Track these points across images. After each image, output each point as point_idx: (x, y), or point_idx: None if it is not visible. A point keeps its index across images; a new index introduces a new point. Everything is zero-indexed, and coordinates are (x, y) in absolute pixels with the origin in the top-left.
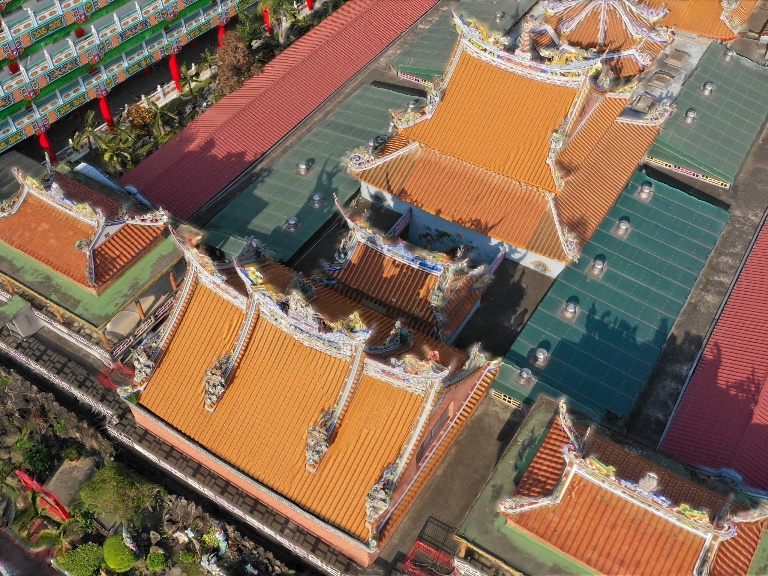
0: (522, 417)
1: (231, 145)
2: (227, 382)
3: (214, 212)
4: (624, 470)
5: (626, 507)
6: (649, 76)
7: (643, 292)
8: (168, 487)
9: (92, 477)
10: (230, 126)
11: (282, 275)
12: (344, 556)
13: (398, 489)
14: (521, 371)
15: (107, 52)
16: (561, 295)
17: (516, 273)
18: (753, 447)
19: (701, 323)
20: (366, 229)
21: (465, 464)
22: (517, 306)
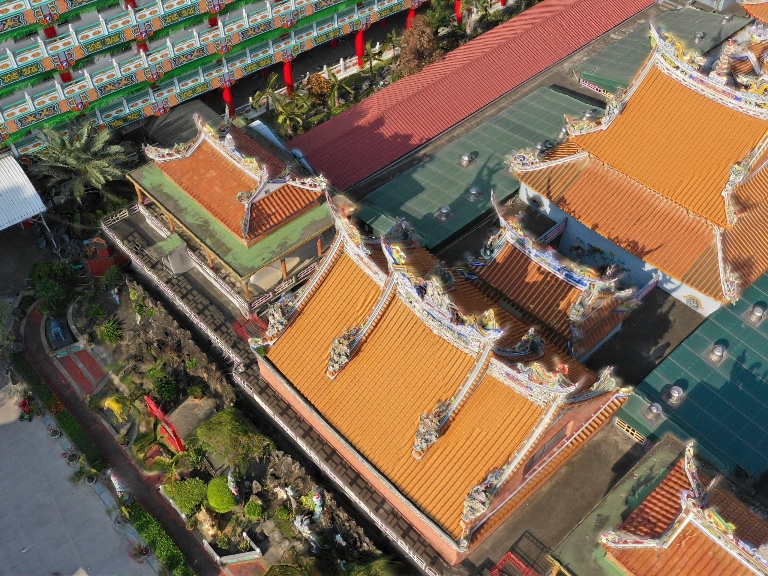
0: (643, 452)
1: (399, 126)
2: (352, 353)
3: (371, 188)
4: (744, 531)
5: (739, 570)
6: None
7: None
8: (278, 442)
9: None
10: (402, 107)
11: (425, 261)
12: (432, 549)
13: (499, 495)
14: (651, 405)
15: (300, 19)
16: (710, 335)
17: (665, 304)
18: None
19: None
20: (517, 230)
21: (573, 487)
22: (660, 338)
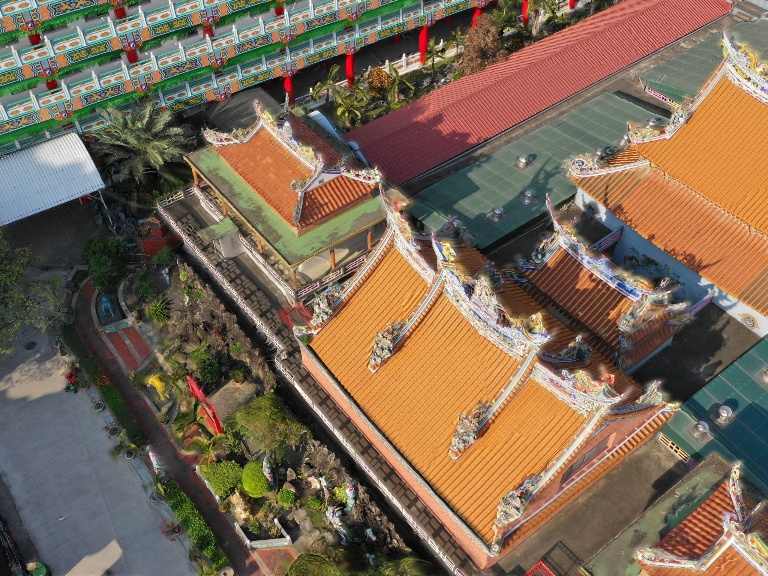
0: (686, 471)
1: (458, 124)
2: (395, 348)
3: (425, 185)
4: None
5: None
6: None
7: None
8: (315, 432)
9: (250, 402)
10: (462, 105)
11: (474, 260)
12: (463, 551)
13: (535, 502)
14: (698, 423)
15: (365, 12)
16: (764, 356)
17: (719, 321)
18: None
19: None
20: (571, 235)
21: (611, 500)
22: (711, 355)
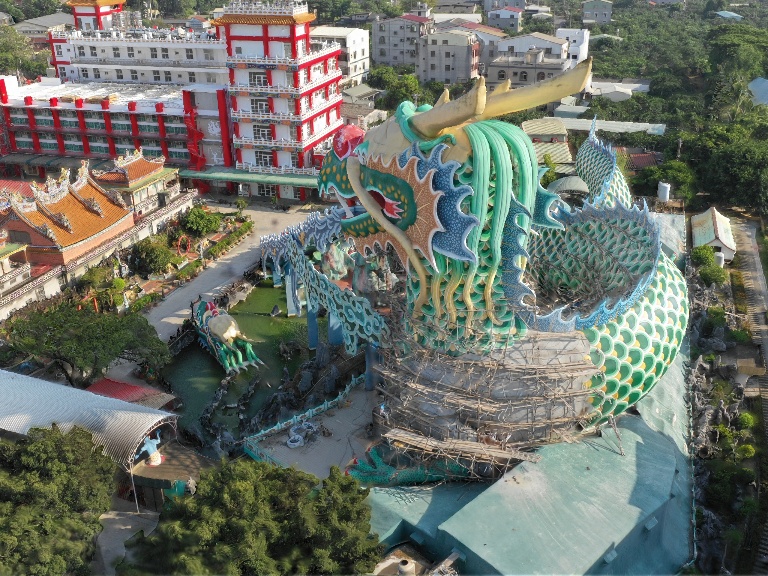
0: None
1: None
2: None
3: None
4: None
5: (131, 165)
6: None
7: None
8: None
9: None
10: None
11: None
12: None
13: None
14: None
15: None
16: None
17: None
18: None
19: None
20: None
21: None
22: None
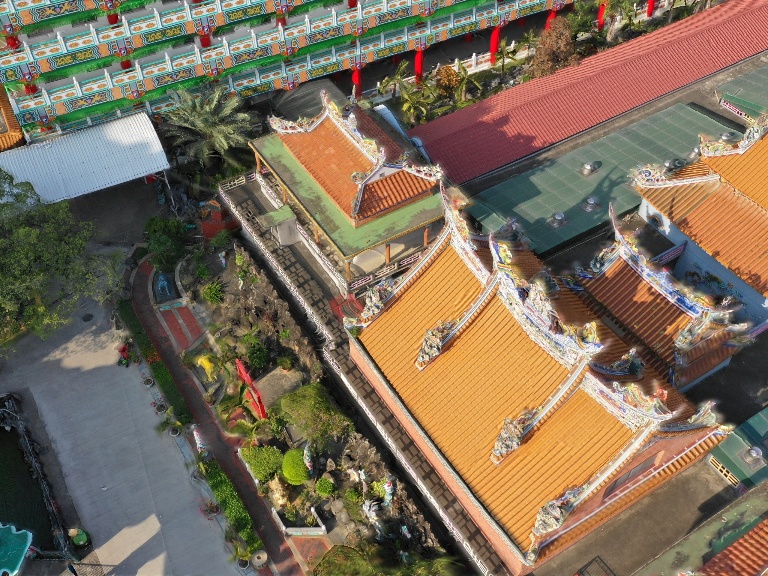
0: (734, 496)
1: (524, 126)
2: (444, 347)
3: (486, 186)
4: None
5: None
6: None
7: None
8: (357, 425)
9: None
10: (529, 108)
11: (531, 265)
12: (498, 557)
13: (575, 514)
14: (751, 448)
15: (438, 9)
16: None
17: None
18: None
19: None
20: (632, 246)
21: (654, 519)
22: None
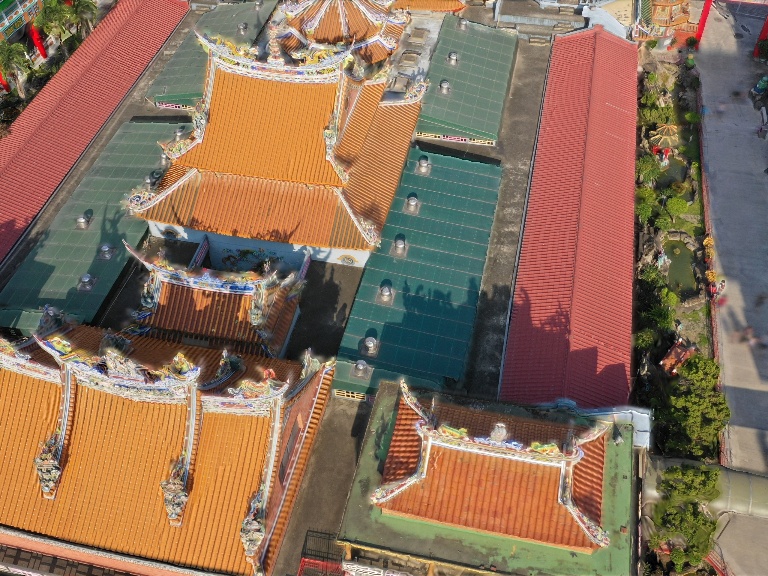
0: (369, 408)
1: None
2: (61, 463)
3: None
4: (474, 428)
5: (485, 462)
6: (398, 58)
7: (447, 259)
8: None
9: None
10: None
11: (90, 337)
12: None
13: (269, 515)
14: (356, 364)
15: None
16: (374, 282)
17: (326, 272)
18: (577, 372)
19: (504, 274)
20: (166, 267)
21: (328, 469)
22: (336, 303)
